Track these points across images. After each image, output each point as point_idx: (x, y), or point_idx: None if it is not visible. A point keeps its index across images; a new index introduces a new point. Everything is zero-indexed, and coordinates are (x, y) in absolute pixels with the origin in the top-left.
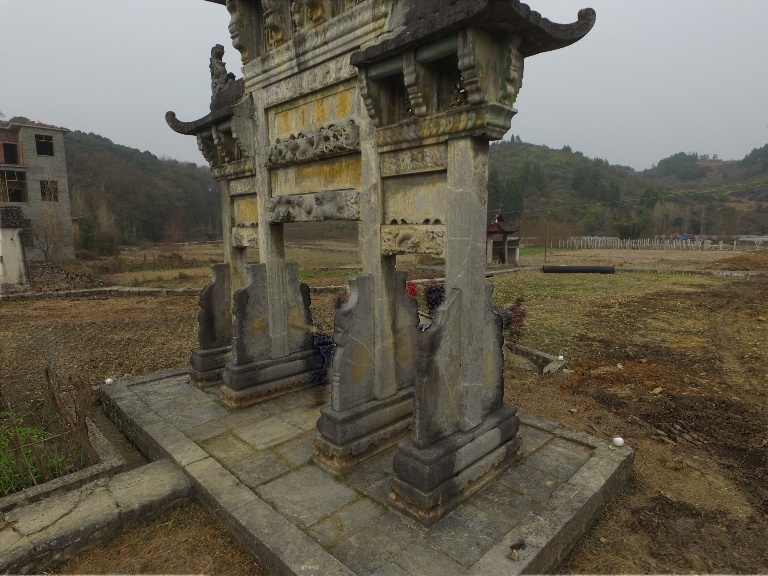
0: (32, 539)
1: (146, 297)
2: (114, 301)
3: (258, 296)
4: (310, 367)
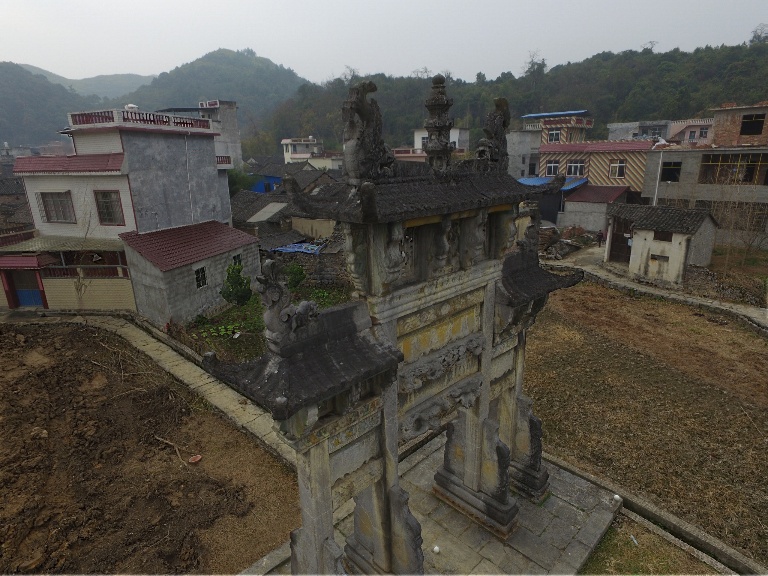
0: None
1: (759, 339)
2: (719, 331)
3: (461, 433)
4: (491, 515)
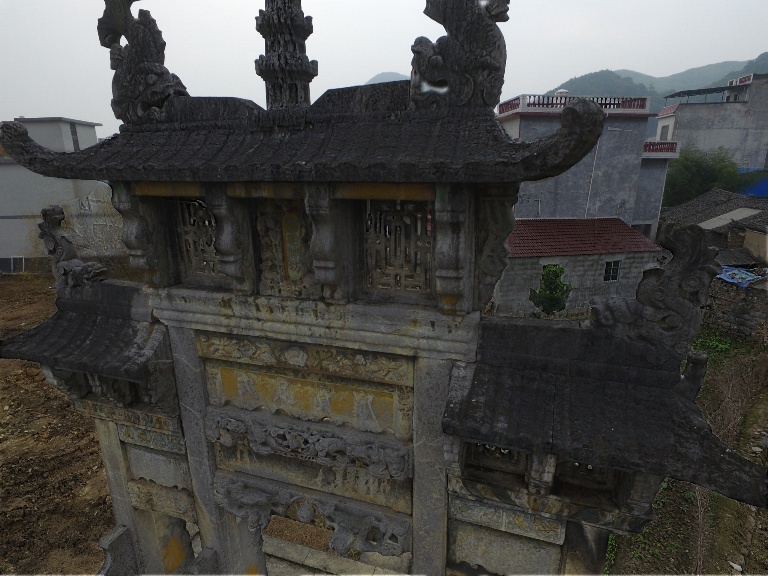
0: None
1: None
2: None
3: None
4: None
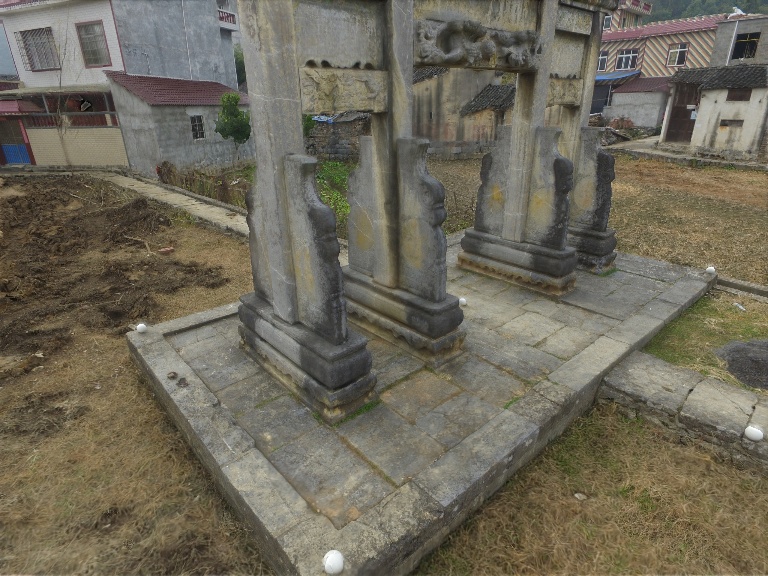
0: None
1: None
2: None
3: (502, 163)
4: (539, 268)
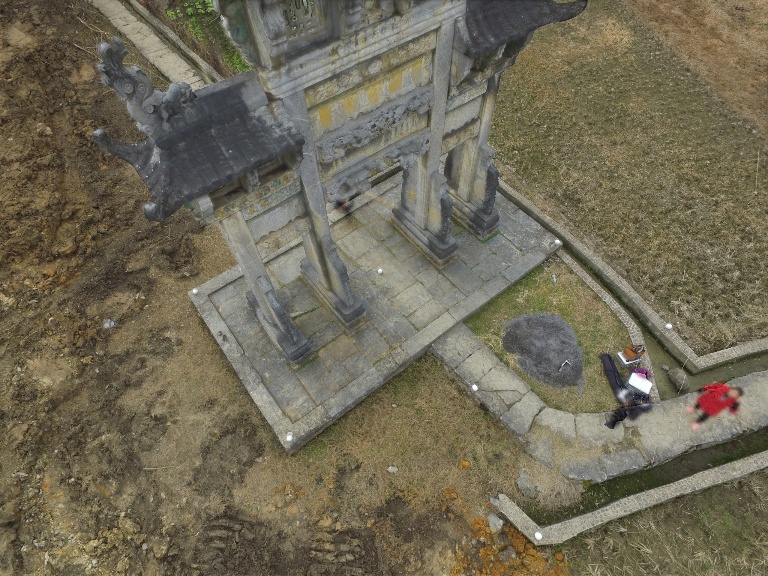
0: None
1: None
2: None
3: (414, 179)
4: (432, 250)
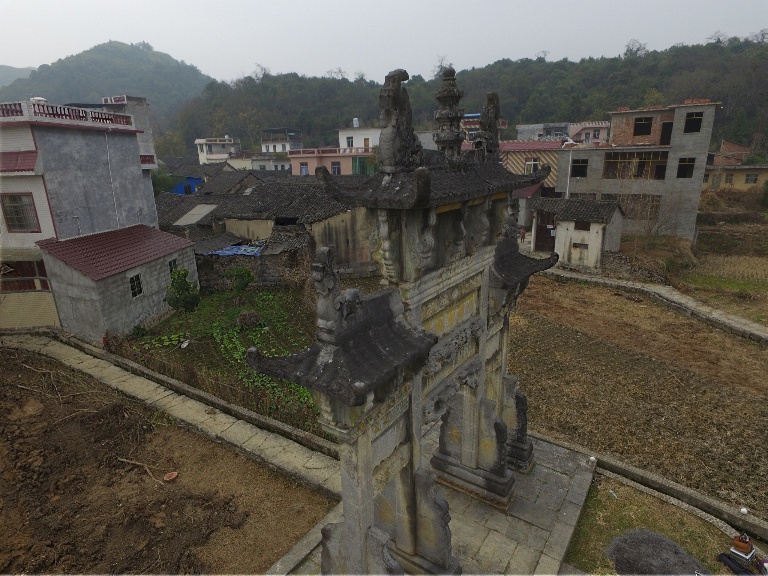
0: (301, 469)
1: (670, 312)
2: (638, 307)
3: (457, 415)
4: (491, 489)
